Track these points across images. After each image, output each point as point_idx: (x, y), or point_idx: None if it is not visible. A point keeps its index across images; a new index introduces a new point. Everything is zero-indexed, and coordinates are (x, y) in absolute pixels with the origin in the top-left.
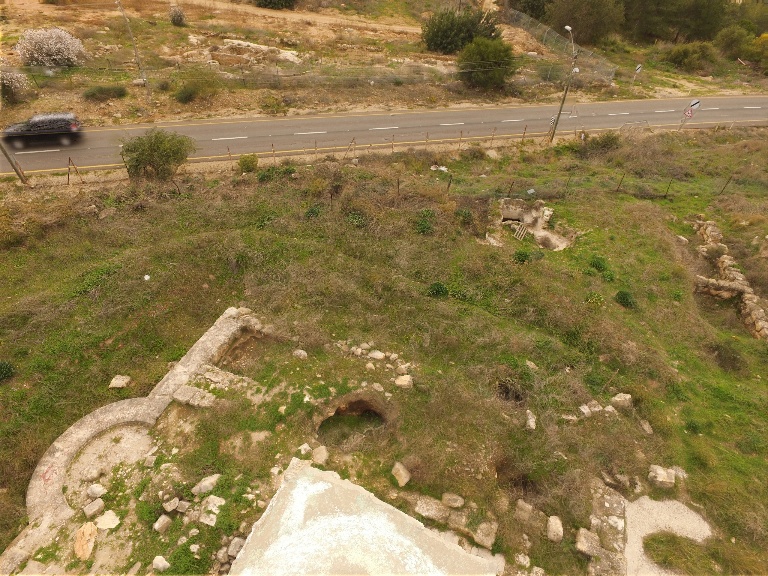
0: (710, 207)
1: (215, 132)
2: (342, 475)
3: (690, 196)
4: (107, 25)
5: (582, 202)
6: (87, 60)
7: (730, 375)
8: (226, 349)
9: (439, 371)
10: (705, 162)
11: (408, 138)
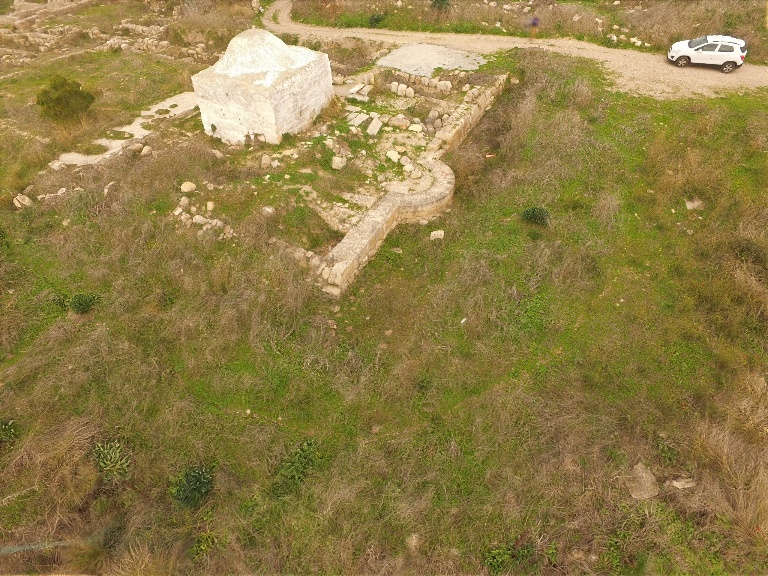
0: None
1: None
2: None
3: None
4: None
5: None
6: None
7: None
8: None
9: None
10: None
11: None
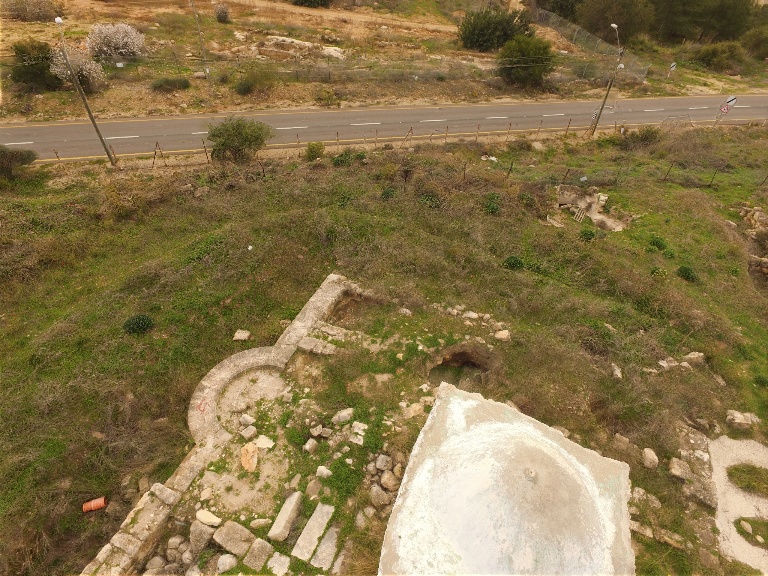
0: (753, 196)
1: (277, 122)
2: None
3: (733, 186)
4: (157, 21)
5: (634, 189)
6: (149, 54)
7: None
8: (332, 309)
9: None
10: (744, 155)
11: (457, 130)
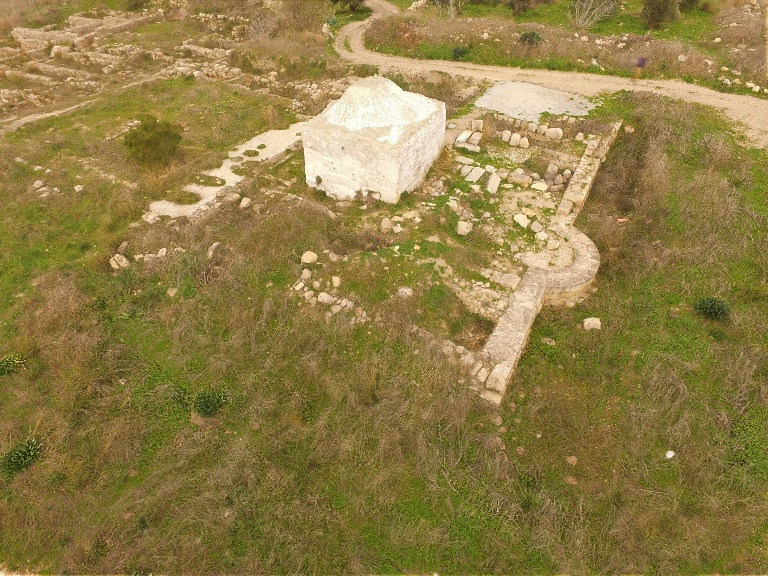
0: None
1: None
2: (372, 218)
3: None
4: None
5: None
6: None
7: None
8: None
9: (269, 285)
10: None
11: None
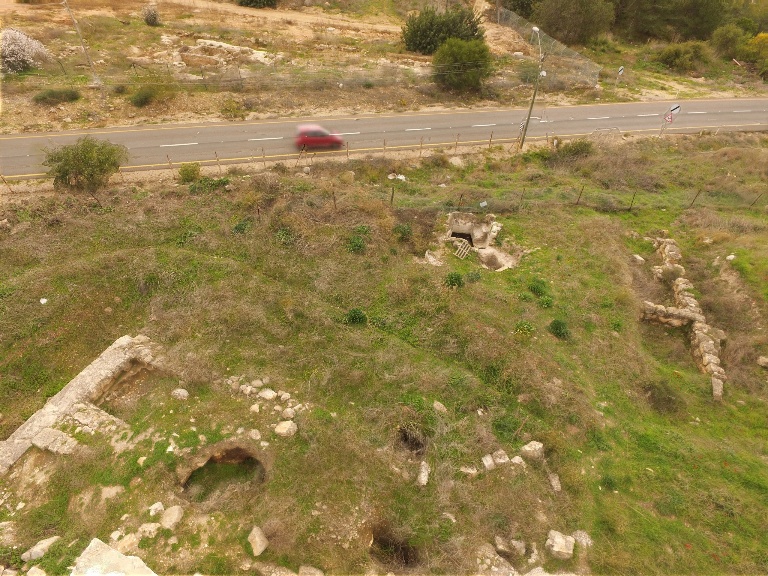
0: (676, 222)
1: (165, 138)
2: (191, 541)
3: (657, 209)
4: None
5: (535, 216)
6: (44, 62)
7: (664, 418)
8: (110, 384)
9: (333, 413)
10: (679, 172)
11: (368, 144)
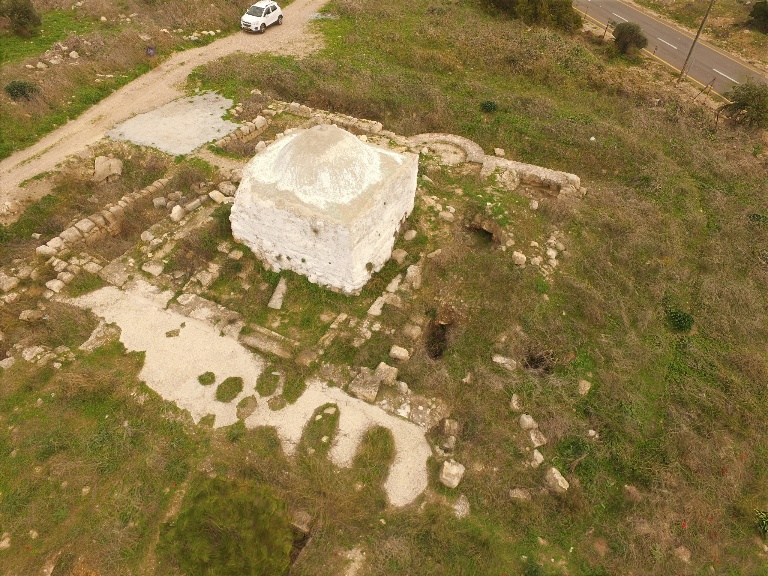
0: None
1: None
2: (434, 227)
3: None
4: None
5: None
6: None
7: None
8: (537, 184)
9: (547, 297)
10: None
11: None
